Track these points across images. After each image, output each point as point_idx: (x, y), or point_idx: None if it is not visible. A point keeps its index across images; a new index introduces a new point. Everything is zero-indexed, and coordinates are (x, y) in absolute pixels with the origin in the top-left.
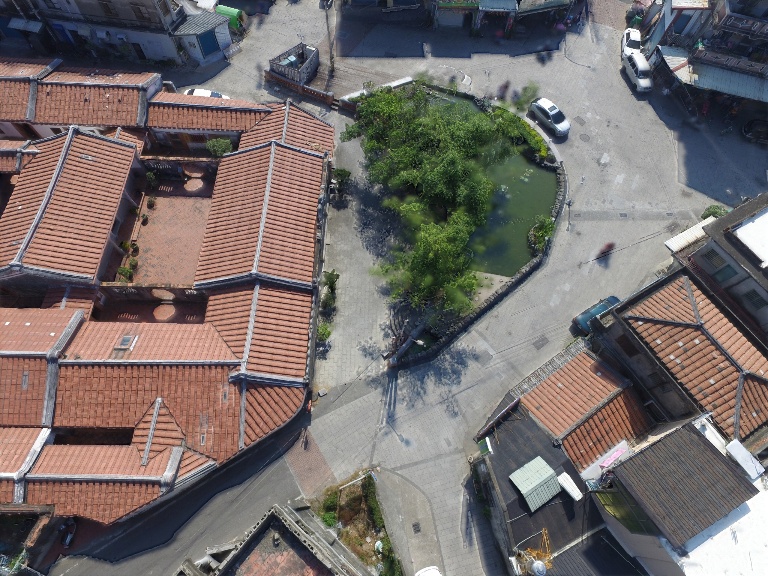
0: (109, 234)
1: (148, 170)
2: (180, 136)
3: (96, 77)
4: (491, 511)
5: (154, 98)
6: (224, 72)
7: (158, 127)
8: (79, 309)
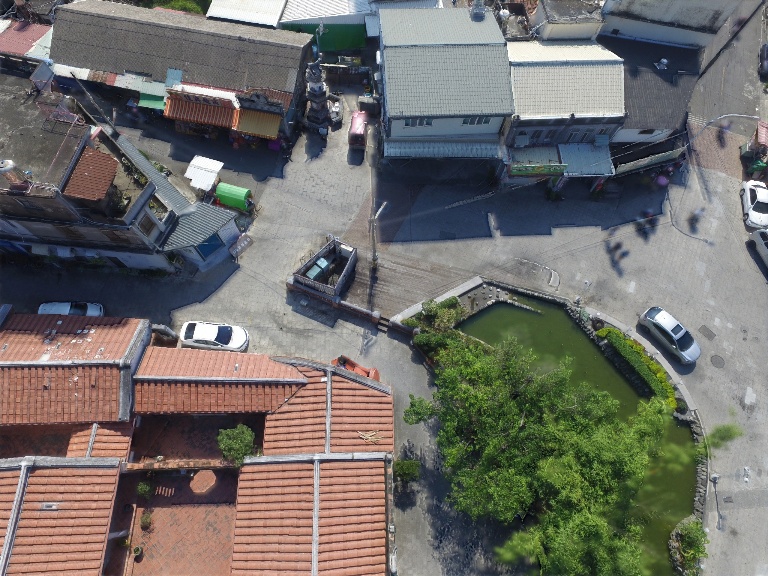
0: None
1: None
2: None
3: (58, 341)
4: None
5: (141, 365)
6: (232, 279)
7: (149, 412)
8: None
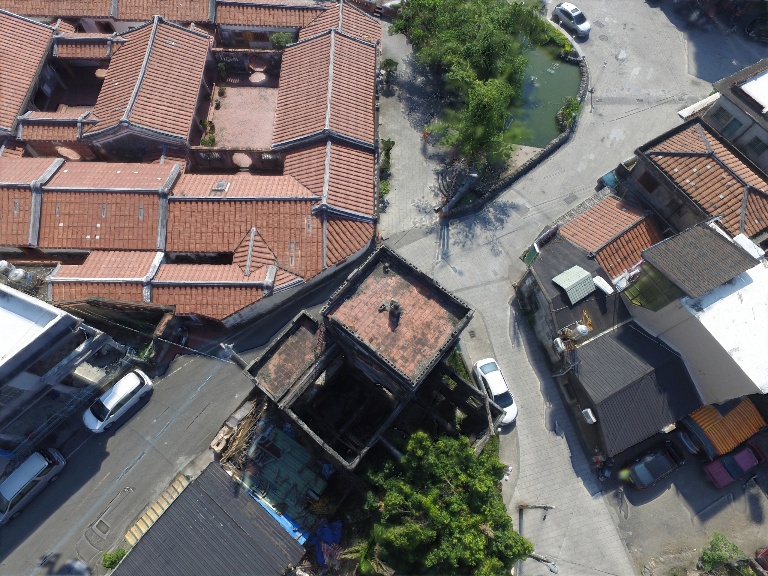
0: (195, 106)
1: (217, 63)
2: (244, 34)
3: None
4: (535, 317)
5: None
6: None
7: (225, 24)
8: None
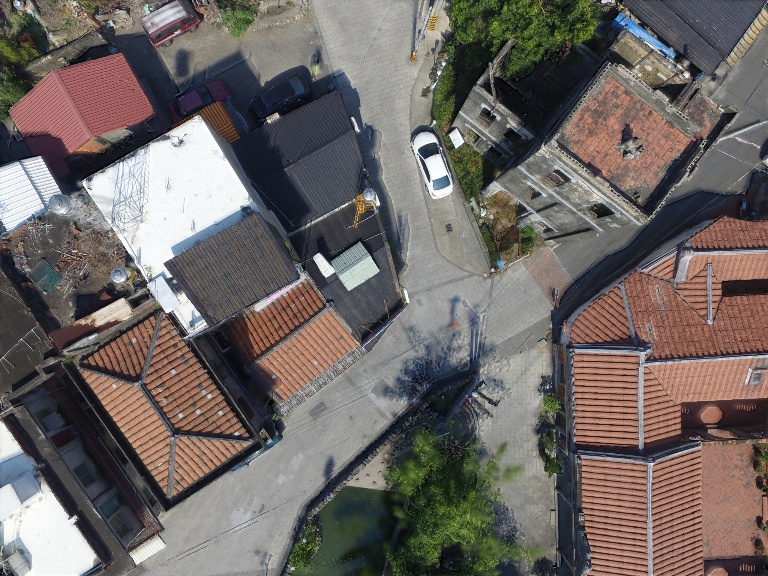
0: None
1: None
2: None
3: None
4: None
5: None
6: None
7: None
8: None
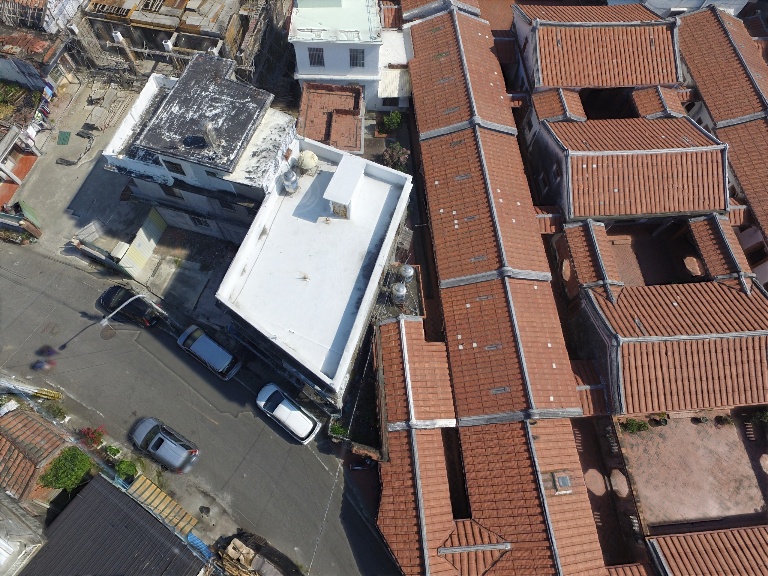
0: None
1: None
2: None
3: None
4: None
5: None
6: None
7: None
8: (581, 404)
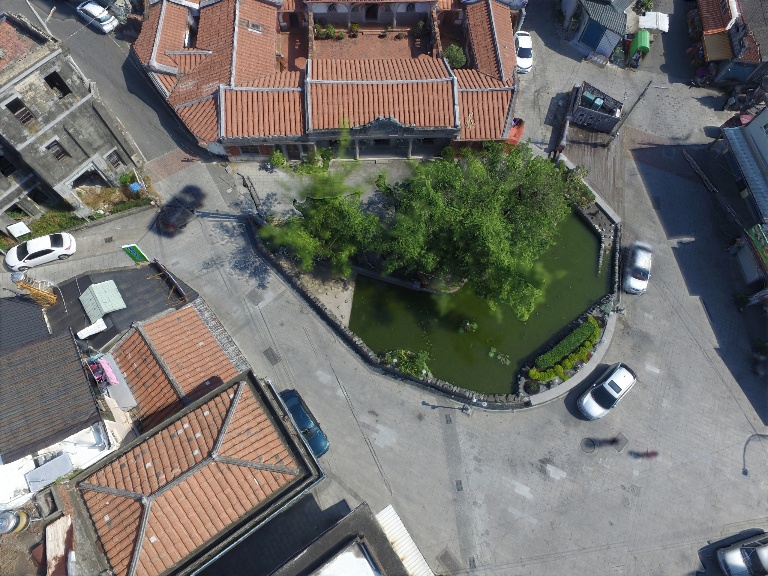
0: (348, 2)
1: None
2: (468, 35)
3: None
4: None
5: (497, 2)
6: (568, 60)
7: (468, 14)
8: (287, 4)
